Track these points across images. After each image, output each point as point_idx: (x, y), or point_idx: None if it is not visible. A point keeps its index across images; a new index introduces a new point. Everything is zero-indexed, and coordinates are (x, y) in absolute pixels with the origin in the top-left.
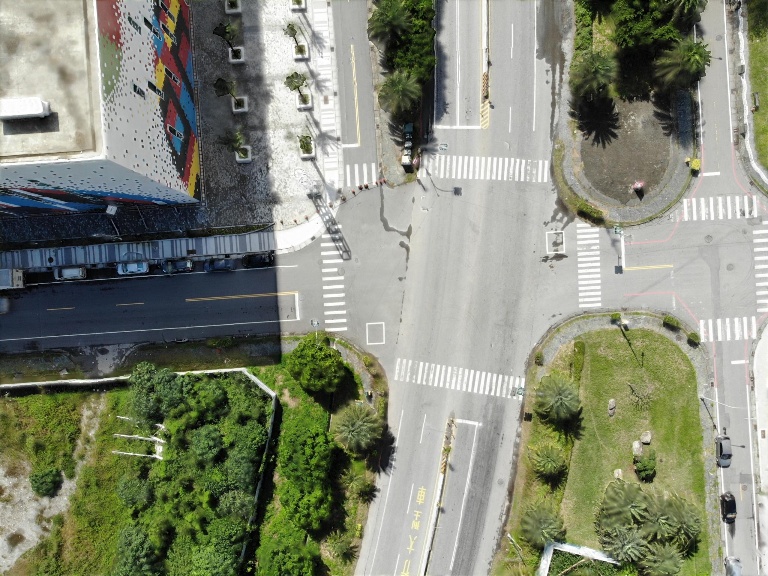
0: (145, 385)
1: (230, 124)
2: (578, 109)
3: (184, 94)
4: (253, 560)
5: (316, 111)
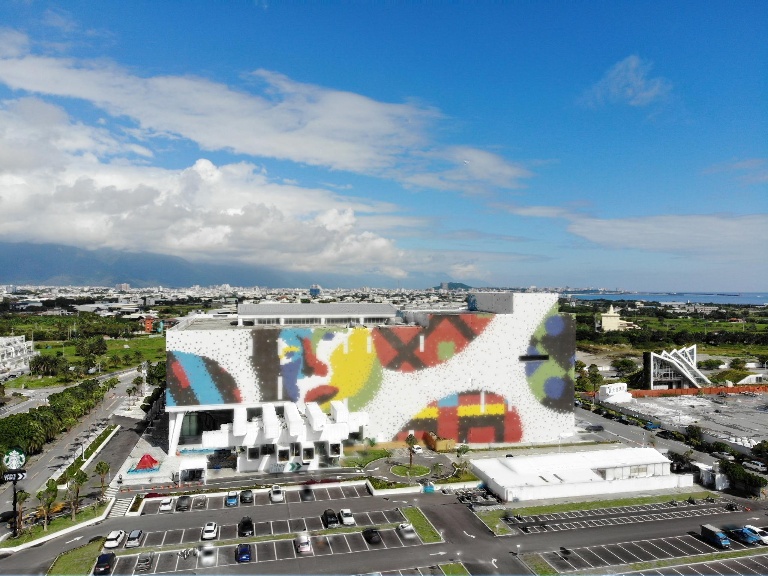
0: None
1: None
2: (2, 405)
3: None
4: None
5: None
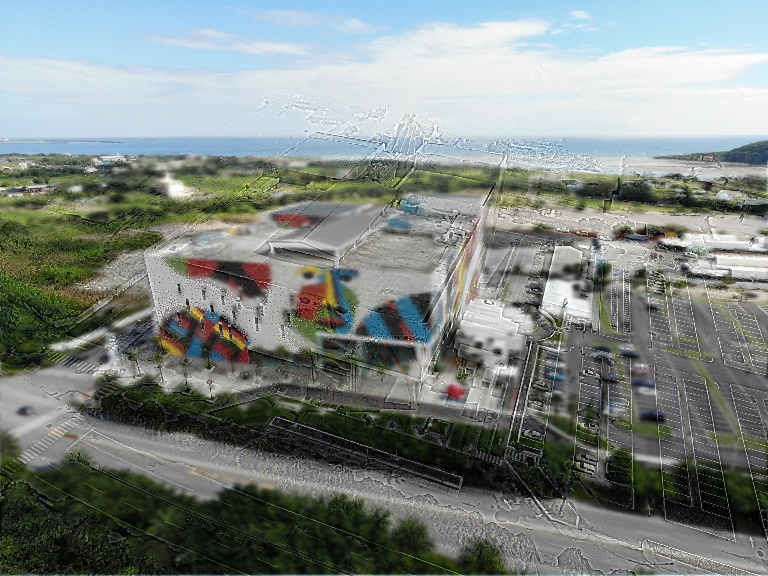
0: (106, 287)
1: (183, 355)
2: None
3: (203, 337)
4: (7, 298)
5: (155, 387)
